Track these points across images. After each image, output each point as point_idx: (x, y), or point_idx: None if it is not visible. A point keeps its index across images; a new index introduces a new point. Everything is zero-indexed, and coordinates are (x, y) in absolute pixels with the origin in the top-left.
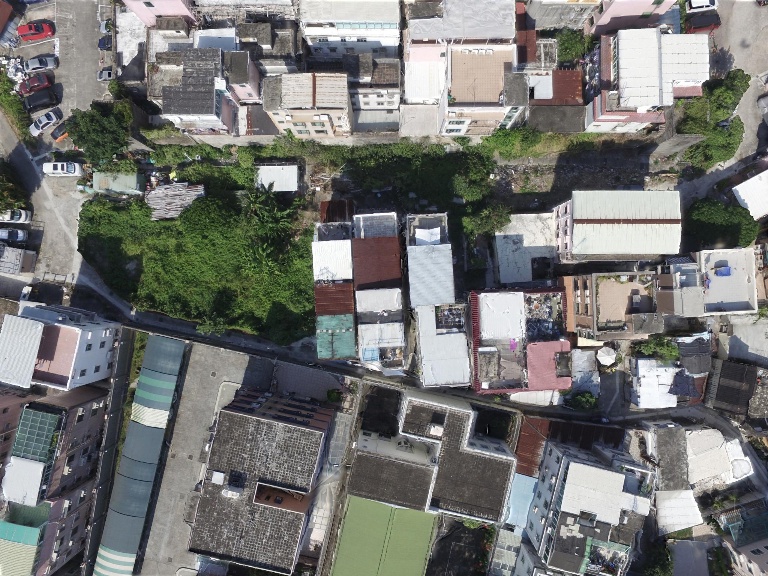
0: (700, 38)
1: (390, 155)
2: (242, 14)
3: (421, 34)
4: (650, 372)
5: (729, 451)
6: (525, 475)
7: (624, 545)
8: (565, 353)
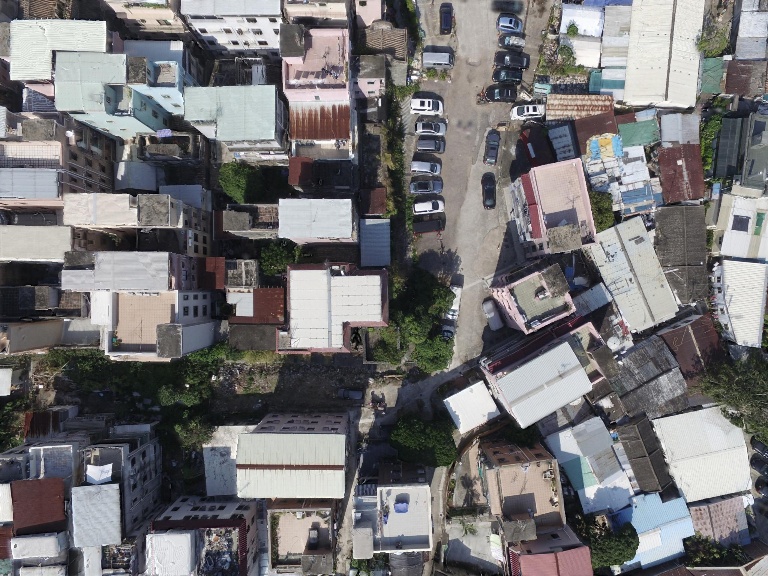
0: (372, 280)
1: None
2: None
3: (73, 285)
4: None
5: None
6: None
7: None
8: None
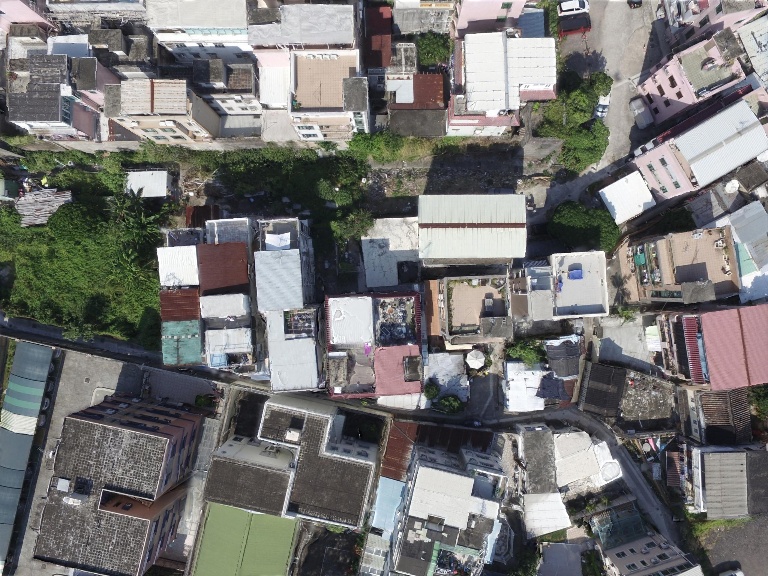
0: (546, 42)
1: (261, 160)
2: (97, 20)
3: (259, 40)
4: (518, 375)
5: (598, 454)
6: (393, 479)
7: (473, 549)
8: (414, 357)
